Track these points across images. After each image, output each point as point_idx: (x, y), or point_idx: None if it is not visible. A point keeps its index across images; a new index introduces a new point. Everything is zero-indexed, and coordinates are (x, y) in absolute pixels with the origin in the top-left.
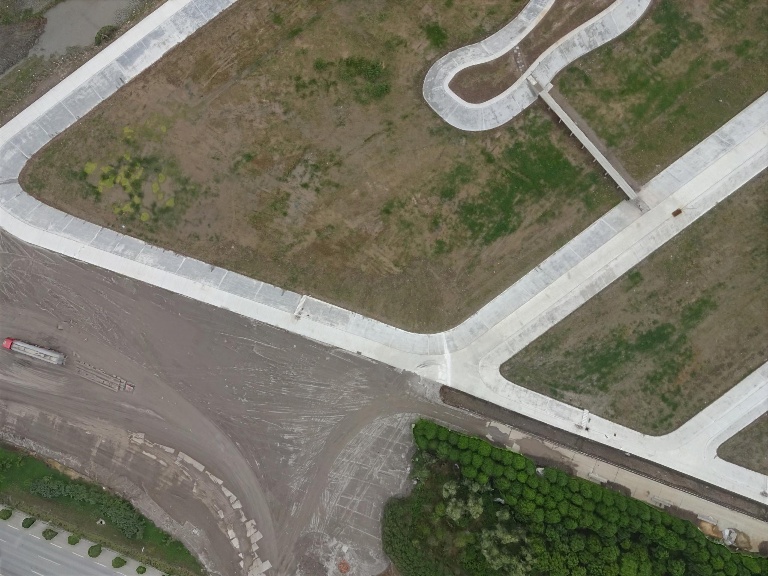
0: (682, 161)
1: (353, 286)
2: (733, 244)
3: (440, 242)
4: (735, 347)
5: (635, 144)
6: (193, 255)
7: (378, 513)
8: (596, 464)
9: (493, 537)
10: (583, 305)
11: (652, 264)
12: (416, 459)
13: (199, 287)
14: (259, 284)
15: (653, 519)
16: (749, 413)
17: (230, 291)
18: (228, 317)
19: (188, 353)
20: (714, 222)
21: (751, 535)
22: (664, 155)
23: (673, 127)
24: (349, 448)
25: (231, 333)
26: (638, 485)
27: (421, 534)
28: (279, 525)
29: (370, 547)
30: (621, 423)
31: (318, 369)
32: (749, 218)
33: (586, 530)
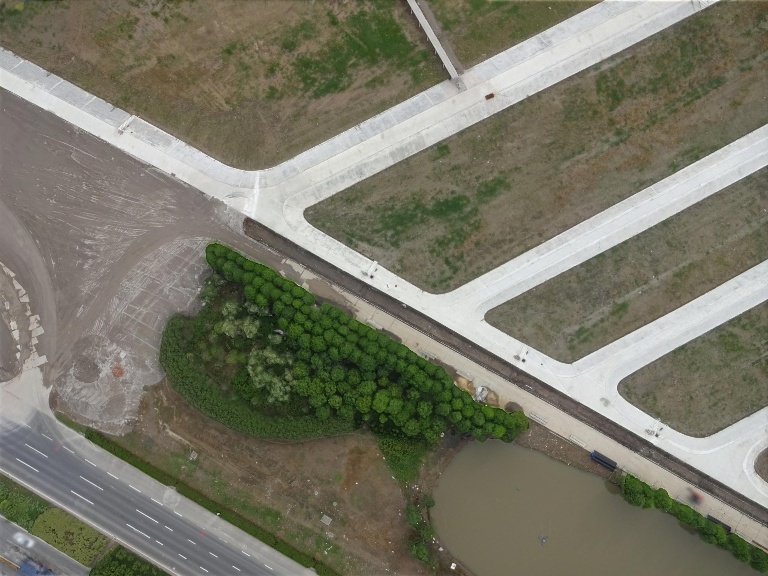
0: (505, 54)
1: (182, 115)
2: (535, 135)
3: (273, 88)
4: (519, 226)
5: (467, 32)
6: (32, 59)
7: (161, 326)
8: (375, 312)
9: (261, 357)
10: (392, 166)
11: (460, 140)
12: (209, 282)
13: (29, 87)
14: (91, 97)
15: (408, 357)
16: (518, 285)
17: (60, 97)
18: (53, 121)
19: (6, 148)
20: (522, 113)
21: (501, 395)
22: (491, 46)
23: (504, 23)
24: (146, 261)
25: (52, 136)
26: (409, 336)
27: (199, 352)
28: (63, 324)
29: (147, 356)
30: (405, 278)
31: (131, 183)
32: (553, 115)
33: (350, 364)
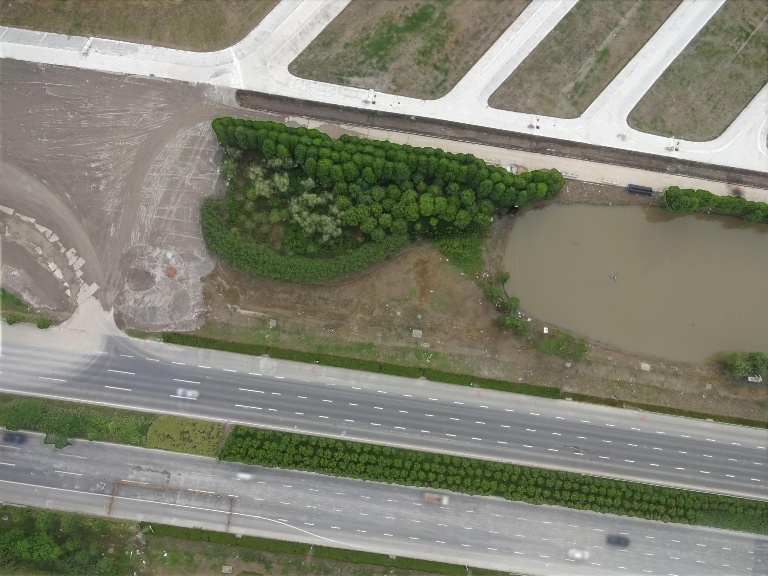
0: None
1: (138, 21)
2: None
3: None
4: (487, 14)
5: None
6: None
7: (196, 216)
8: (389, 135)
9: (302, 204)
10: (353, 1)
11: None
12: (224, 162)
13: None
14: (43, 34)
15: (436, 152)
16: (507, 64)
17: (12, 42)
18: (14, 66)
19: None
20: None
21: (529, 167)
22: None
23: None
24: (157, 163)
25: (20, 80)
26: (428, 145)
27: (241, 227)
28: (100, 248)
29: (194, 248)
30: (403, 95)
31: (114, 97)
32: None
33: (385, 183)
